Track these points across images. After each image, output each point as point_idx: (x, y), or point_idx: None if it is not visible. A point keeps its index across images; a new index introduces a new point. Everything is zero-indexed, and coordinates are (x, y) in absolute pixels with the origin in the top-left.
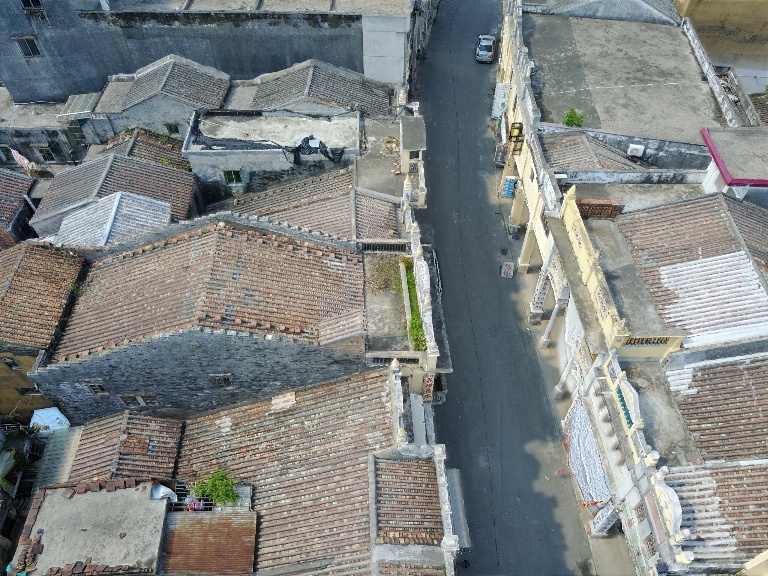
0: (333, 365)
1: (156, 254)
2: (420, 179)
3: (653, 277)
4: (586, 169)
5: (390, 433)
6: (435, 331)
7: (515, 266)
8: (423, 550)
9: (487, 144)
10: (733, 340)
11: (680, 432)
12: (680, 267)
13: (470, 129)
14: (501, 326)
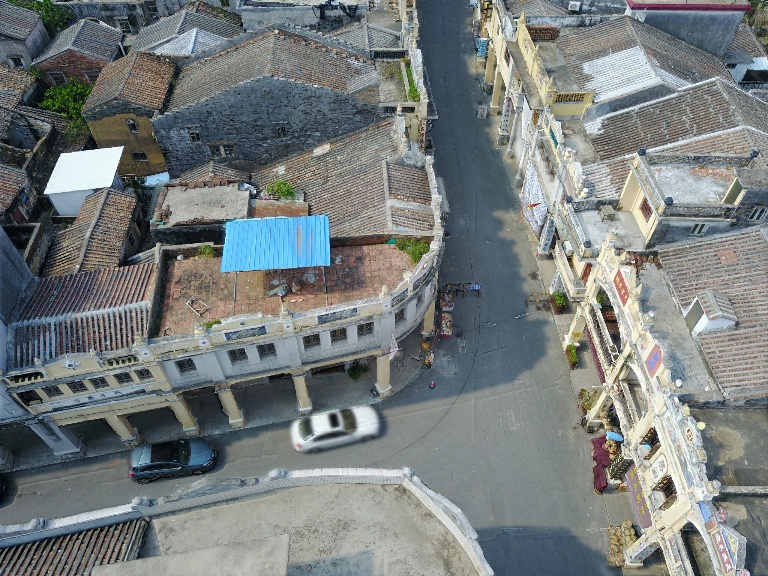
0: (357, 115)
1: (230, 55)
2: (414, 19)
3: (578, 69)
4: (536, 15)
5: (396, 149)
6: None
7: (488, 111)
8: (419, 205)
9: (468, 36)
10: (626, 93)
11: (591, 154)
12: (596, 61)
13: (454, 26)
14: (477, 147)
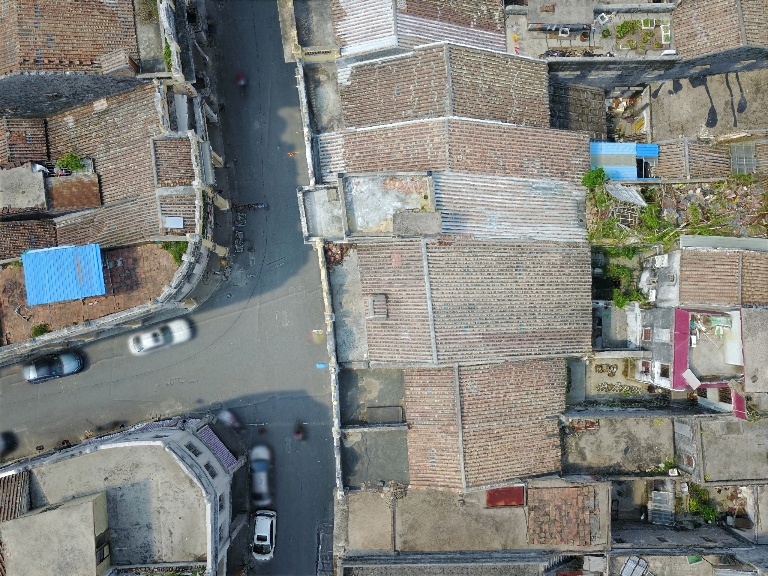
0: (120, 83)
1: None
2: None
3: None
4: None
5: None
6: (184, 53)
7: None
8: (184, 188)
9: None
10: (367, 50)
11: (338, 110)
12: None
13: None
14: (275, 17)
